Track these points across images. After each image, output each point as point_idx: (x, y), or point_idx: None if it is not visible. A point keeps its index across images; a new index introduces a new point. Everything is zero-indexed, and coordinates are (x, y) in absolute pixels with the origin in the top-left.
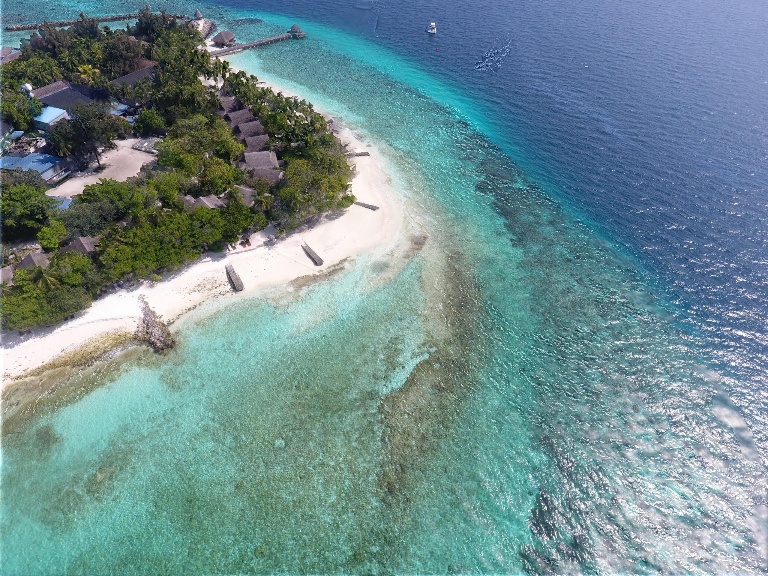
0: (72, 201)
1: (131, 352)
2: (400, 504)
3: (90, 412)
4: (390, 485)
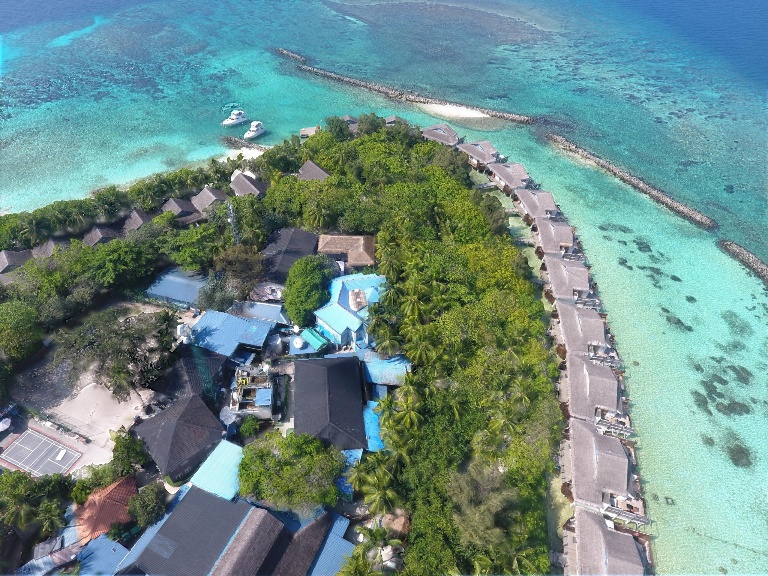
0: (150, 252)
1: (123, 190)
2: (6, 139)
3: (148, 170)
4: (5, 143)
